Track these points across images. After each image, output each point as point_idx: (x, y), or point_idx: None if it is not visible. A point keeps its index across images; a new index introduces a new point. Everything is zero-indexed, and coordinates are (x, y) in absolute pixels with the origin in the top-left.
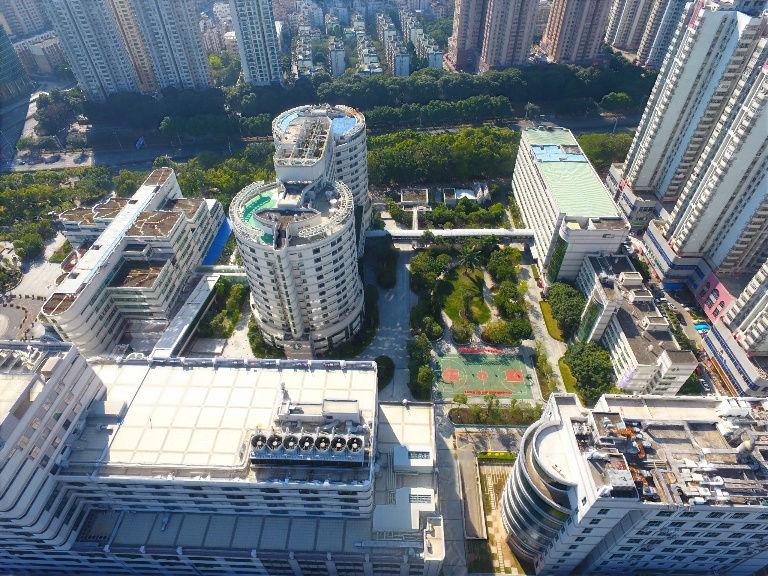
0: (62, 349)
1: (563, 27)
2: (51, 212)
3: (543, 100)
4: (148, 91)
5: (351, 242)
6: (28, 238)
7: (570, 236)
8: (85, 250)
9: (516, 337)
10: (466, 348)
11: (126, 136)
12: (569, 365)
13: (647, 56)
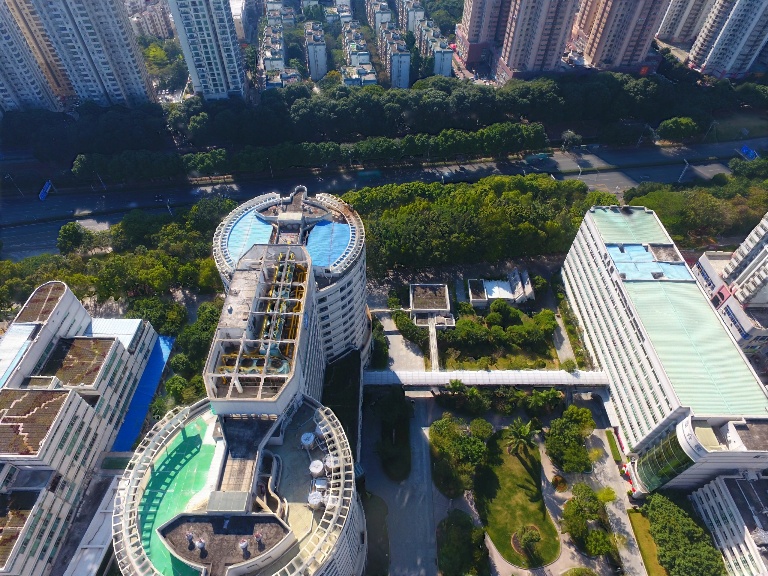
0: None
1: (608, 21)
2: None
3: (581, 119)
4: (68, 96)
5: (350, 532)
6: None
7: (702, 457)
8: None
9: None
10: None
11: (26, 180)
12: None
13: (705, 57)
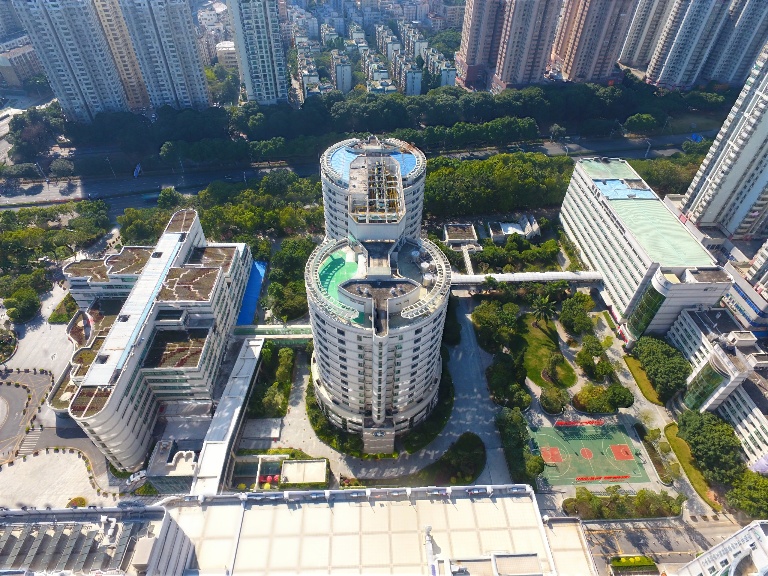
0: (149, 516)
1: (580, 44)
2: (42, 258)
3: (563, 120)
4: (135, 108)
5: None
6: (21, 295)
7: (670, 290)
8: (97, 311)
9: (618, 406)
10: (560, 419)
11: (120, 163)
12: (688, 441)
13: (658, 74)
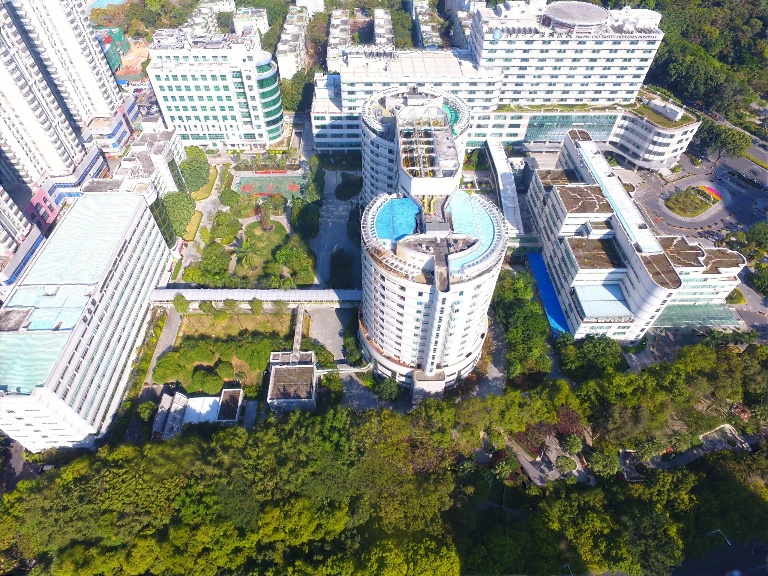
0: None
1: None
2: None
3: None
4: None
5: None
6: None
7: None
8: None
9: None
10: None
11: None
12: None
13: None
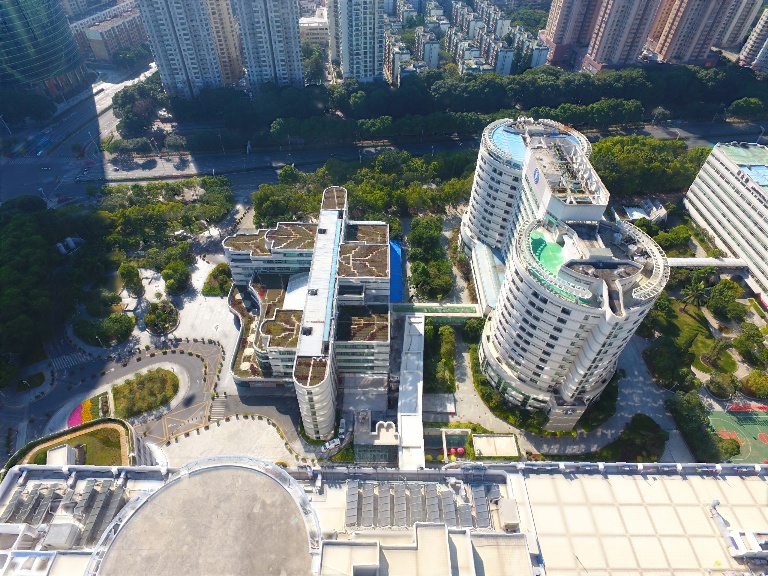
0: (489, 479)
1: (680, 24)
2: (179, 232)
3: (660, 103)
4: (225, 84)
5: None
6: (176, 267)
7: None
8: (259, 285)
9: None
10: (730, 404)
11: (231, 139)
12: None
13: (755, 56)
